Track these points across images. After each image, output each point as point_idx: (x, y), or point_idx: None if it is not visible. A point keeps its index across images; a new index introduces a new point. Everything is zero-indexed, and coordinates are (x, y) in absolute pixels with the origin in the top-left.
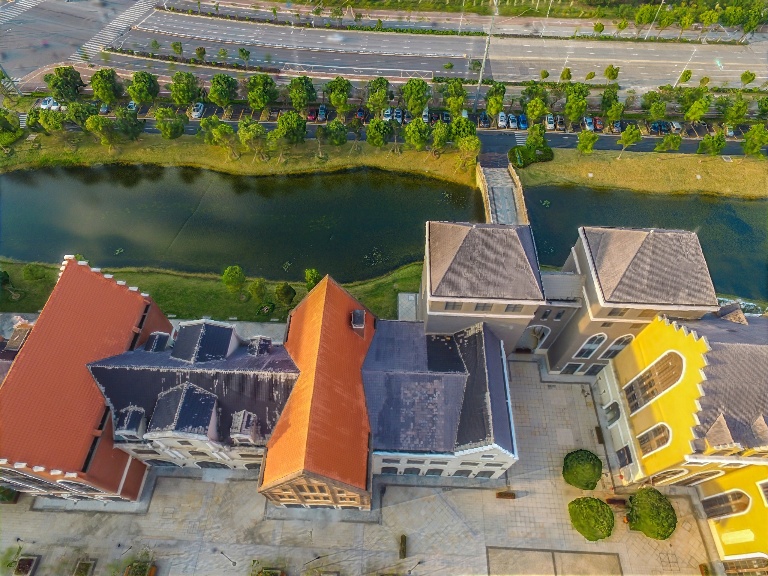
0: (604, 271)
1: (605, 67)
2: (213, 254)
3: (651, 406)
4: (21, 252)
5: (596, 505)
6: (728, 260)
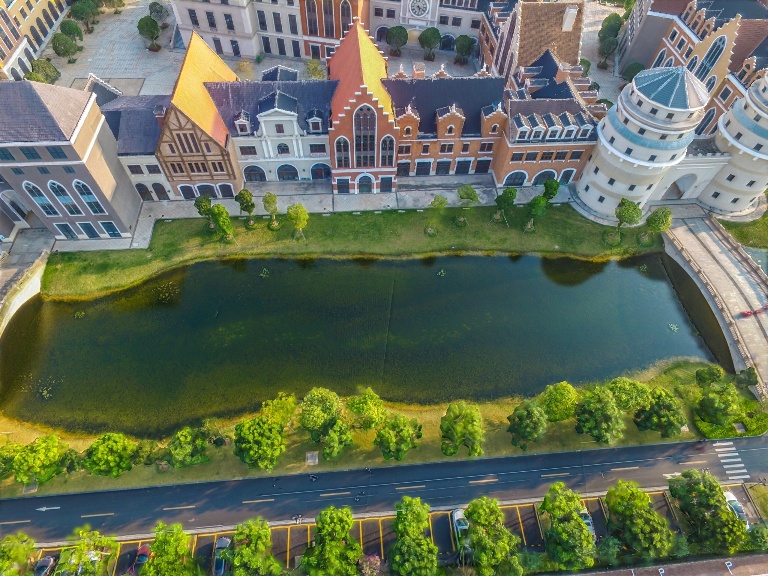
0: None
1: None
2: (345, 279)
3: None
4: (537, 263)
5: None
6: None
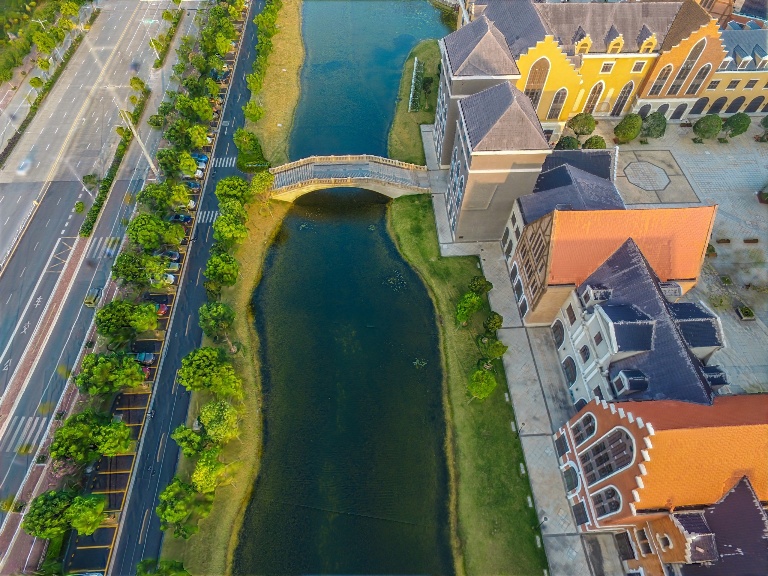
0: (498, 69)
1: (106, 95)
2: (415, 455)
3: (542, 98)
4: None
5: (595, 140)
6: (368, 76)
